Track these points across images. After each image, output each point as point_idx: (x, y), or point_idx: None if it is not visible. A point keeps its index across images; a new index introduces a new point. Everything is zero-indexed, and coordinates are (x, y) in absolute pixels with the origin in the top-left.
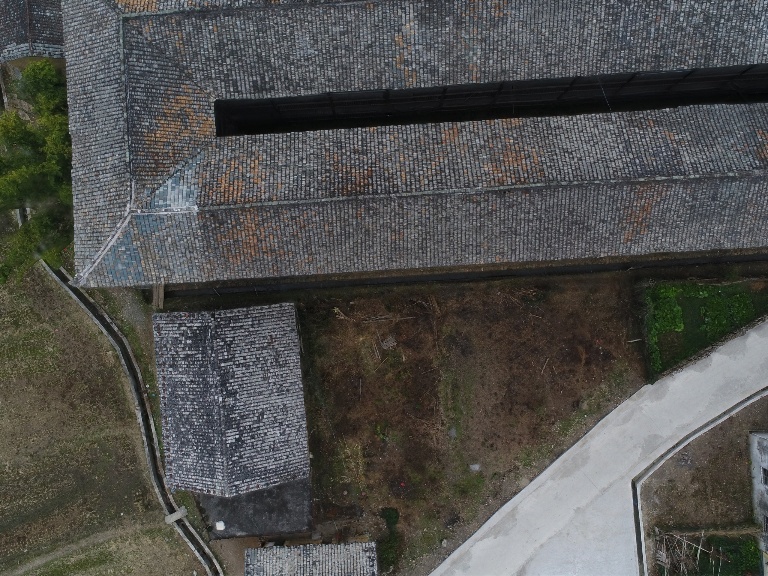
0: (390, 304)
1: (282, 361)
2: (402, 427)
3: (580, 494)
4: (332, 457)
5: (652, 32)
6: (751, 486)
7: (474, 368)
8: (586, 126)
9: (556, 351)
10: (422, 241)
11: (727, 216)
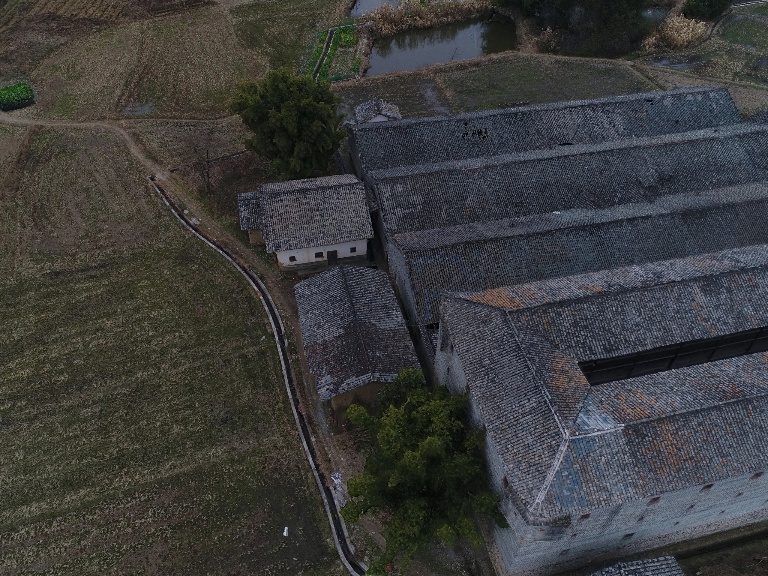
0: (737, 566)
1: None
2: None
3: None
4: None
5: None
6: None
7: None
8: None
9: None
10: None
11: None
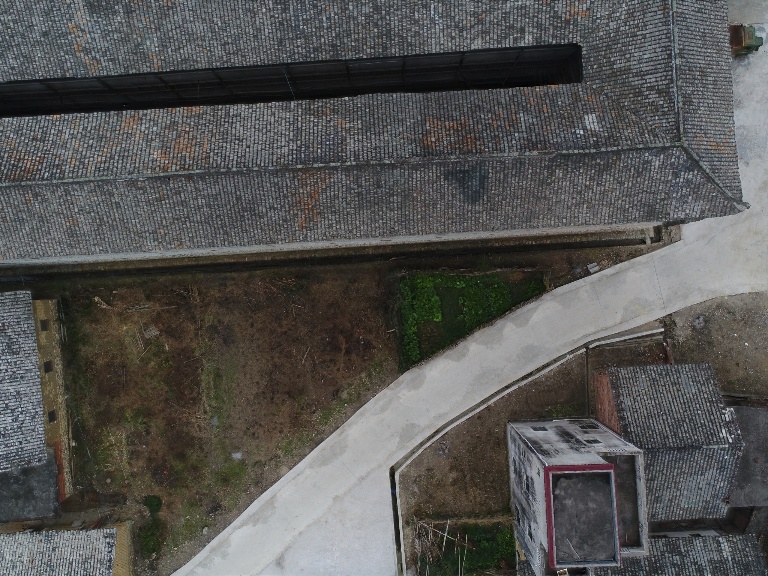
0: (151, 293)
1: (16, 348)
2: (165, 415)
3: (338, 482)
4: (97, 445)
5: (324, 21)
6: (508, 475)
7: (236, 357)
8: (264, 114)
9: (317, 340)
10: (98, 227)
11: (396, 203)
